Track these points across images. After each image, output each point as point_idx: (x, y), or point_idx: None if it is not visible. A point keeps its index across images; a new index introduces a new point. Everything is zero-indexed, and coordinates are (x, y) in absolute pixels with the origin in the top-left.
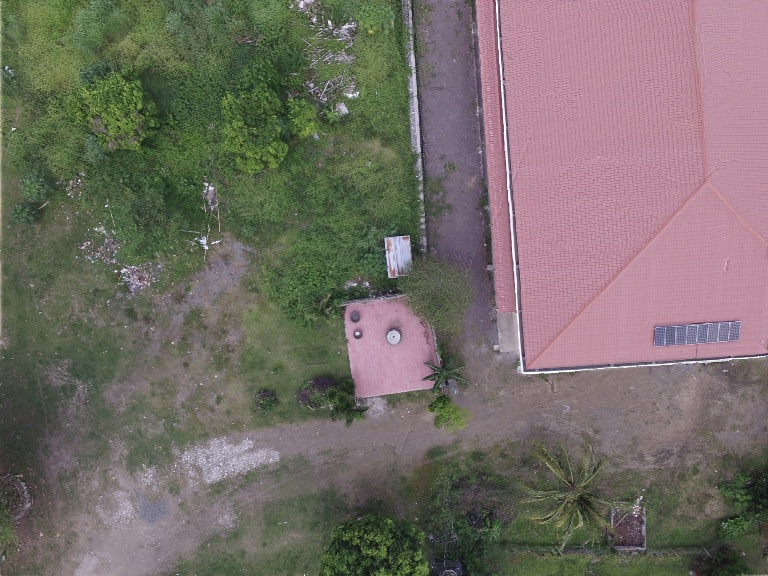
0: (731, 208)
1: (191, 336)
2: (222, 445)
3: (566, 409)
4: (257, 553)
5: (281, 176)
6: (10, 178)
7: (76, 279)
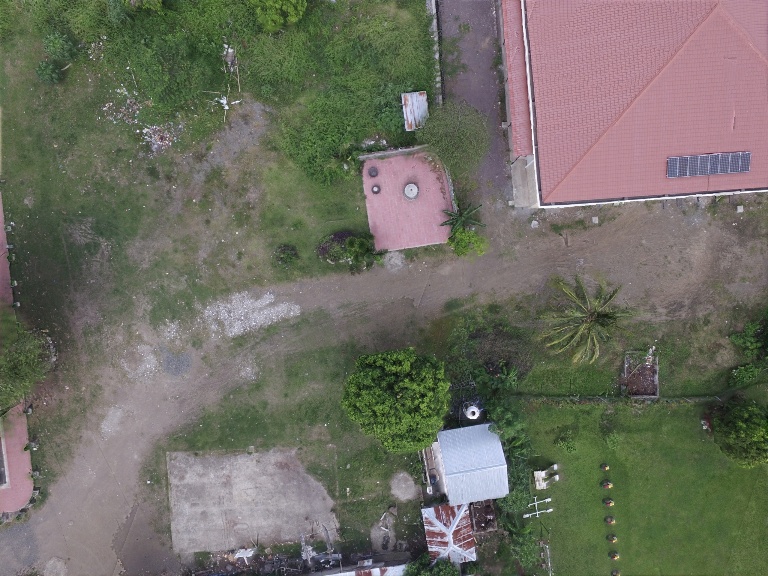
0: (742, 28)
1: (212, 194)
2: (244, 300)
3: (580, 262)
4: (279, 404)
5: (299, 36)
6: (33, 42)
7: (99, 139)
